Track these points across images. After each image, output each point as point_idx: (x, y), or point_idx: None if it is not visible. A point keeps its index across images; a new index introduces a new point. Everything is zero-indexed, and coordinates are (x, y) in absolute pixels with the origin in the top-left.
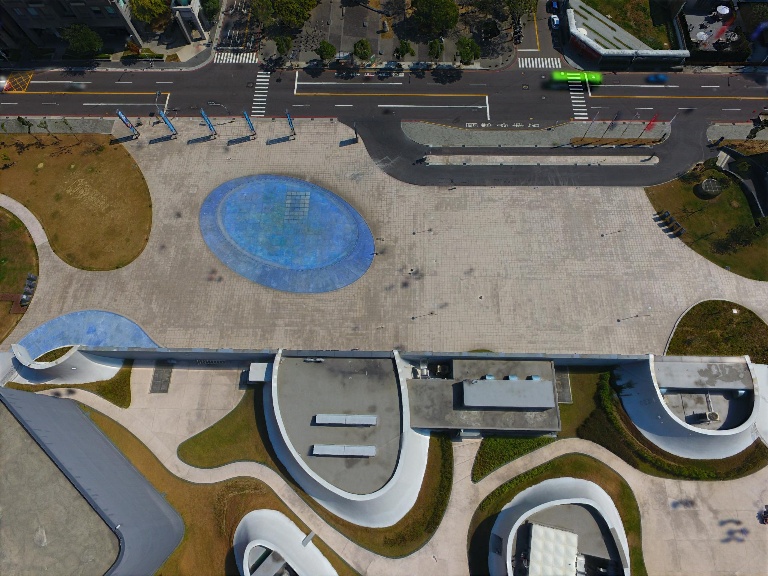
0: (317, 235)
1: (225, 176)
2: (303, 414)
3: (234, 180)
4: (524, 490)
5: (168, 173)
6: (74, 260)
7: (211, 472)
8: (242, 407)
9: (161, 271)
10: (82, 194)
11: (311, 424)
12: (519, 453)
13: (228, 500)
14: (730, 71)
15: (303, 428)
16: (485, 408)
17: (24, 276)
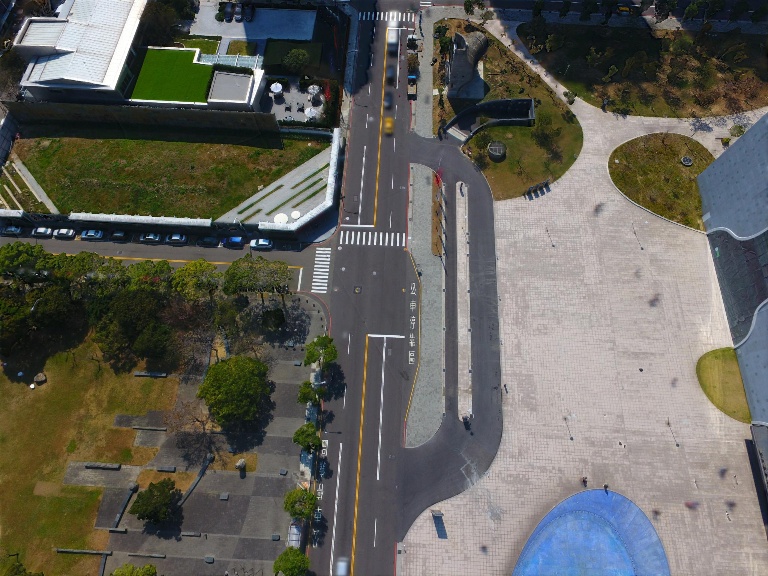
0: (587, 570)
1: None
2: None
3: None
4: None
5: None
6: None
7: None
8: None
9: None
10: None
11: None
12: None
13: None
14: (348, 102)
15: None
16: None
17: None
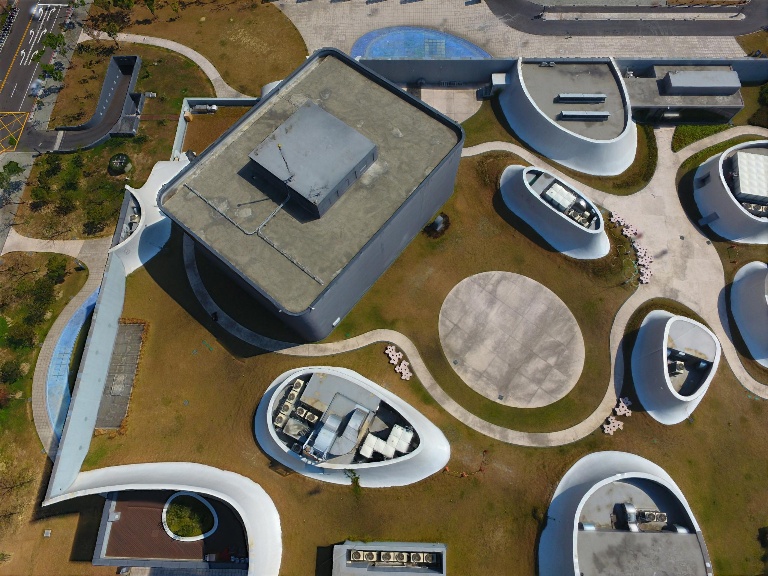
0: None
1: (368, 27)
2: (546, 97)
3: (377, 30)
4: (714, 155)
5: (317, 25)
6: (246, 90)
7: (468, 149)
8: (482, 111)
9: None
10: (244, 41)
11: (554, 102)
12: (706, 134)
13: (487, 164)
14: None
15: (548, 105)
16: (684, 94)
17: None
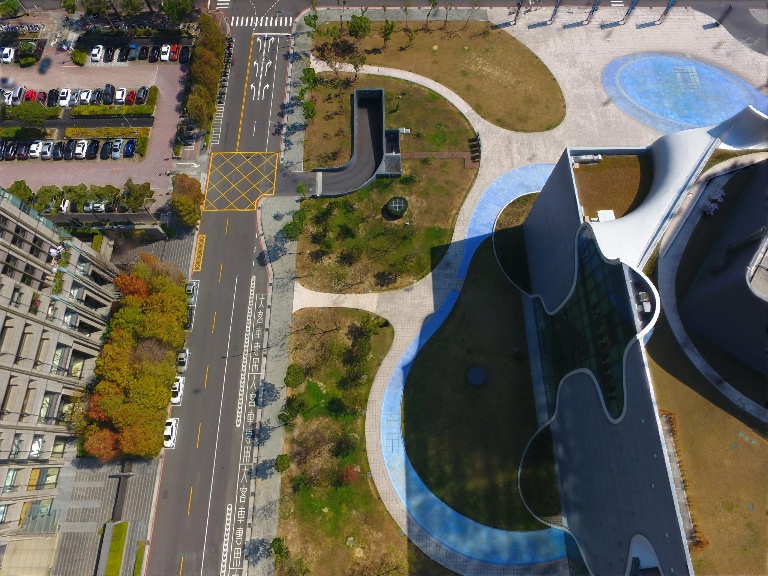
0: (717, 100)
1: (612, 54)
2: None
3: (621, 57)
4: None
5: (558, 52)
6: (505, 124)
7: None
8: None
9: (590, 131)
10: (486, 70)
11: None
12: None
13: None
14: None
15: None
16: None
17: (464, 138)
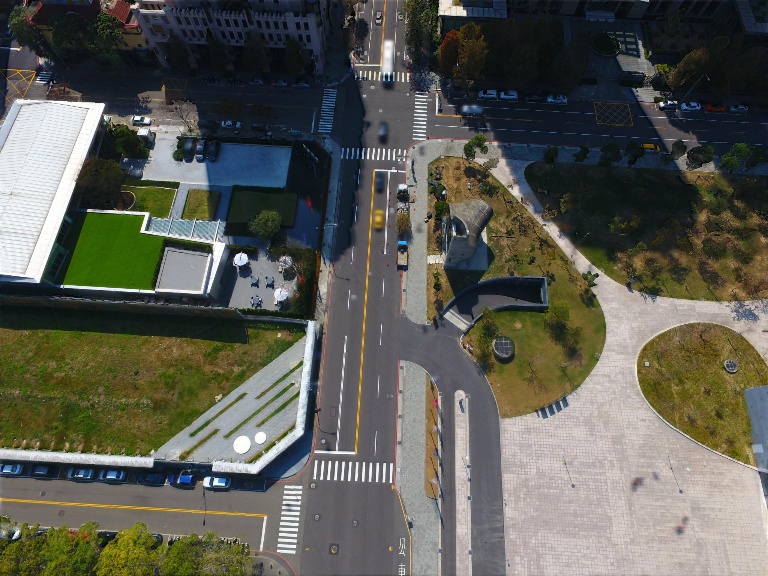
0: None
1: None
2: None
3: None
4: None
5: None
6: None
7: None
8: None
9: None
10: None
11: None
12: None
13: None
14: (327, 272)
15: None
16: None
17: None
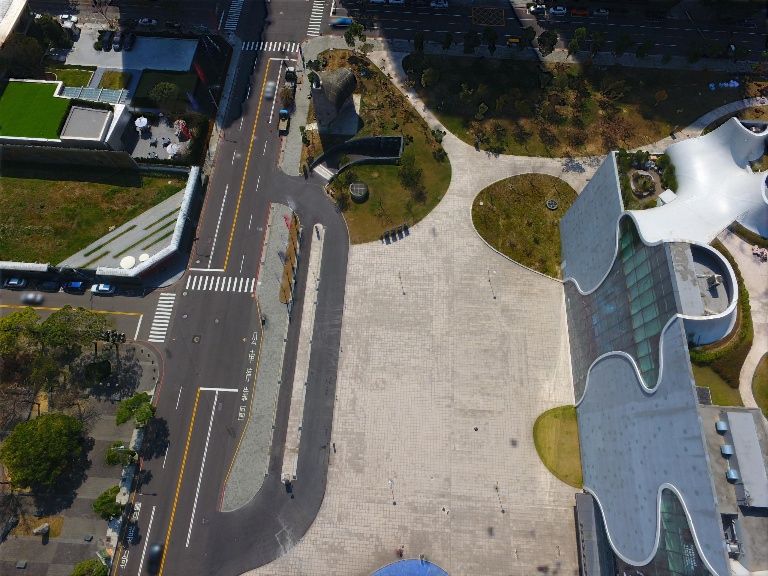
0: None
1: None
2: None
3: None
4: None
5: None
6: None
7: None
8: None
9: None
10: None
11: None
12: None
13: None
14: (218, 137)
15: None
16: None
17: None
